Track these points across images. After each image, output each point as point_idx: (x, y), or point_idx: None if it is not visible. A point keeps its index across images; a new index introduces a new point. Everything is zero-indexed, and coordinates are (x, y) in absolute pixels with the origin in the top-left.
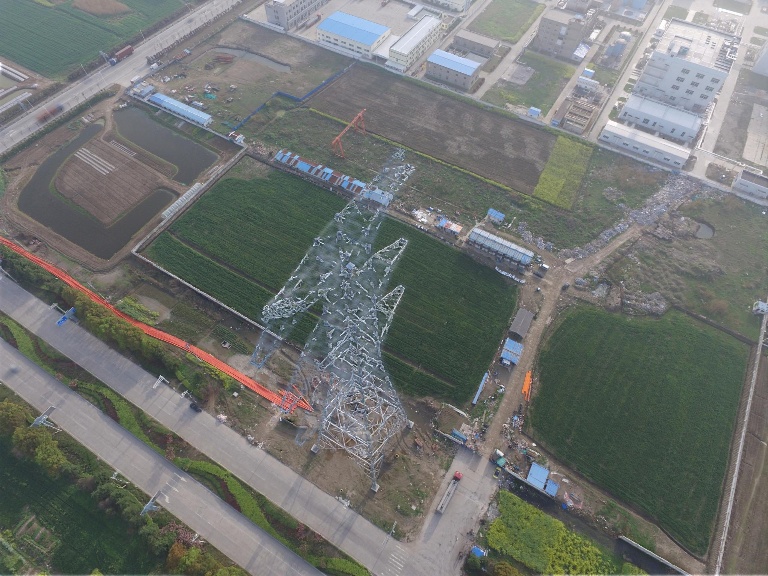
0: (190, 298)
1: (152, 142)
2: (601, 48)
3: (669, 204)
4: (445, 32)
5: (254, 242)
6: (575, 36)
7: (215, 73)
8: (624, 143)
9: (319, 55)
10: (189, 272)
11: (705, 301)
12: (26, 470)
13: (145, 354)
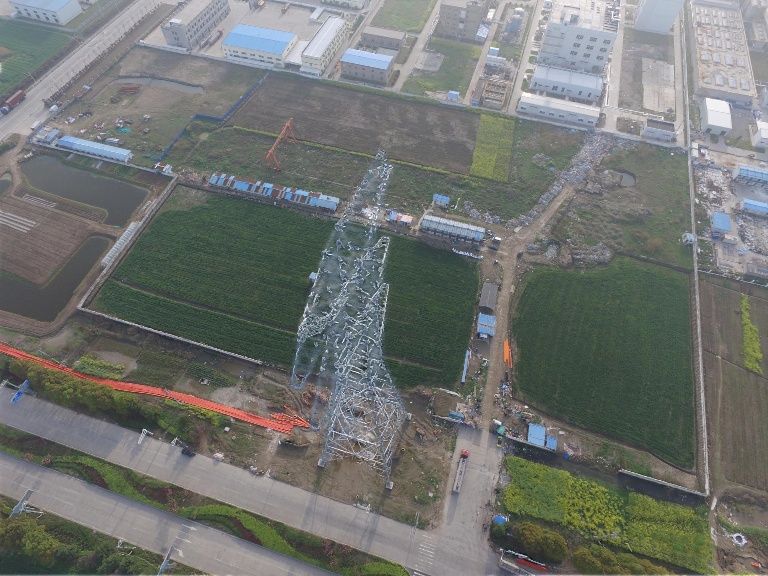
0: (154, 342)
1: (71, 189)
2: (500, 26)
3: (592, 161)
4: (351, 31)
5: (208, 272)
6: (475, 18)
7: (123, 106)
8: (541, 111)
9: (230, 71)
10: (146, 316)
11: (642, 242)
12: (15, 565)
13: (120, 411)
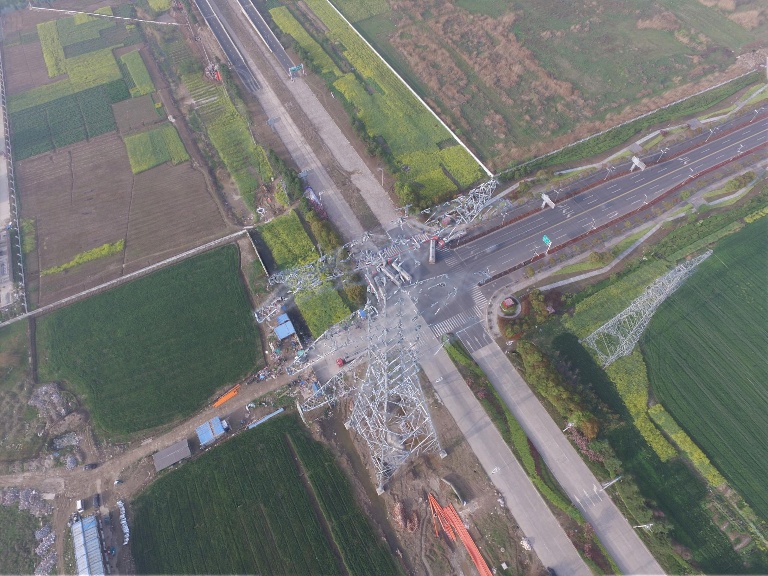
0: None
1: None
2: None
3: None
4: None
5: None
6: None
7: None
8: None
9: None
10: None
11: (8, 370)
12: None
13: None
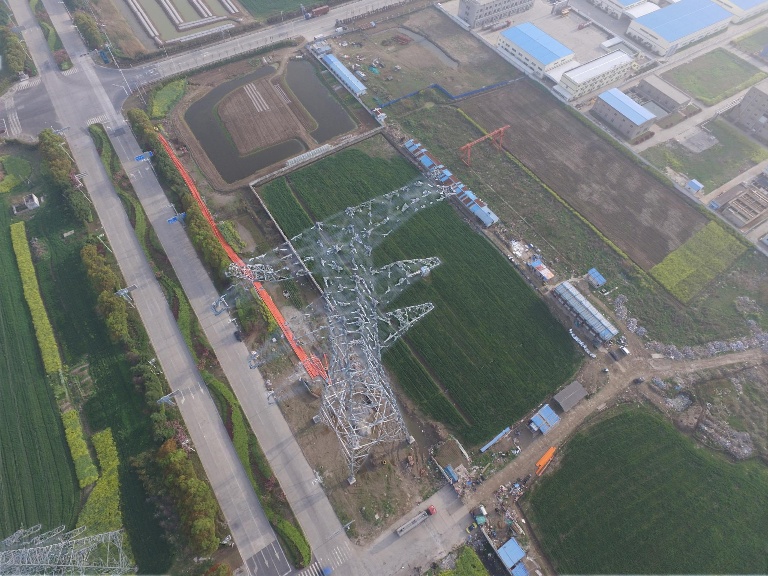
0: (276, 242)
1: (308, 96)
2: None
3: None
4: (634, 73)
5: None
6: None
7: (388, 50)
8: None
9: (491, 60)
10: (286, 219)
11: None
12: (98, 326)
13: (220, 274)
